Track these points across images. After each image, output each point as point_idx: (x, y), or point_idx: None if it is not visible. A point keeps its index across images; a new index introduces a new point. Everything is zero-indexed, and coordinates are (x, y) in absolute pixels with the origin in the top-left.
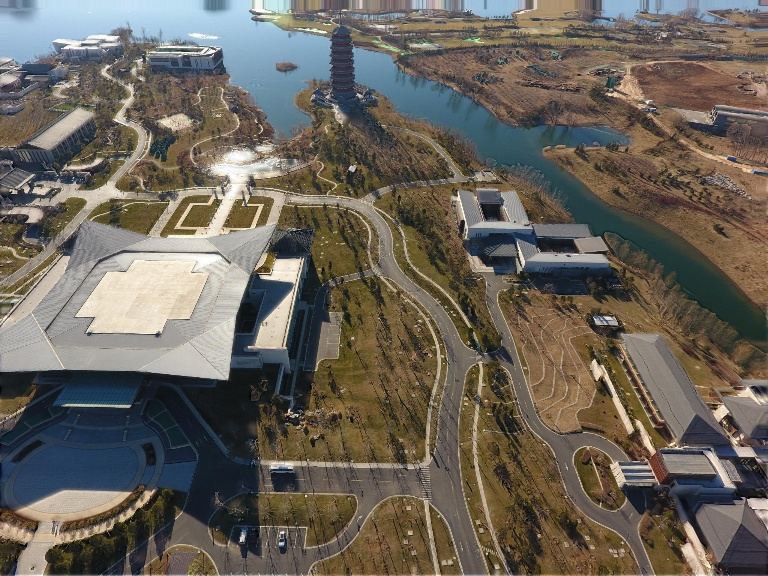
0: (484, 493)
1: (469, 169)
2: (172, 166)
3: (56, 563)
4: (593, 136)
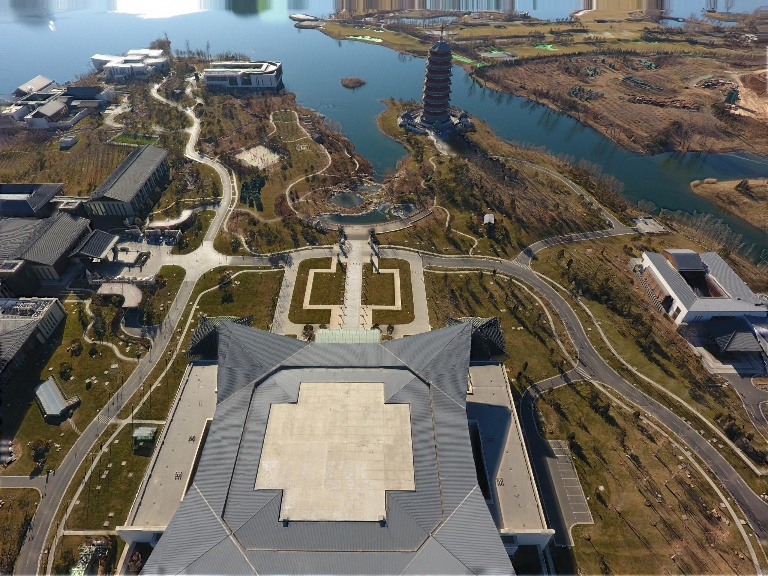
0: None
1: (628, 216)
2: (272, 217)
3: None
4: (739, 165)
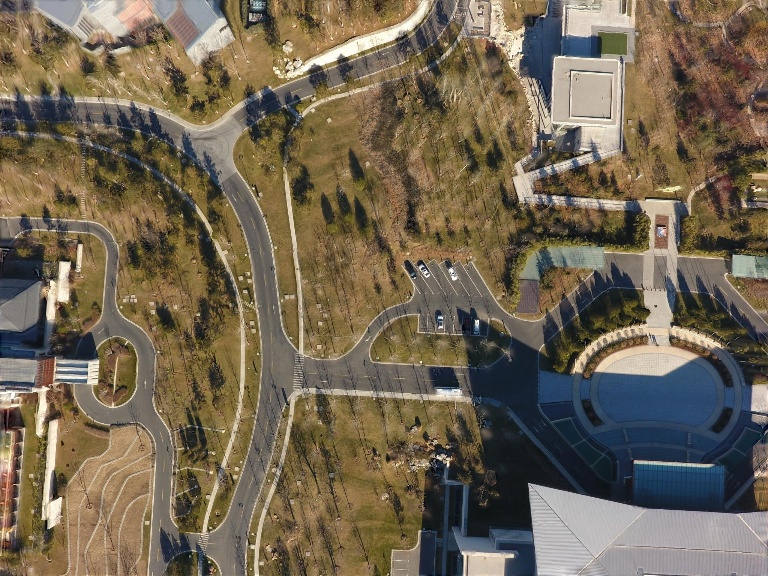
0: (241, 359)
1: None
2: None
3: (638, 308)
4: None
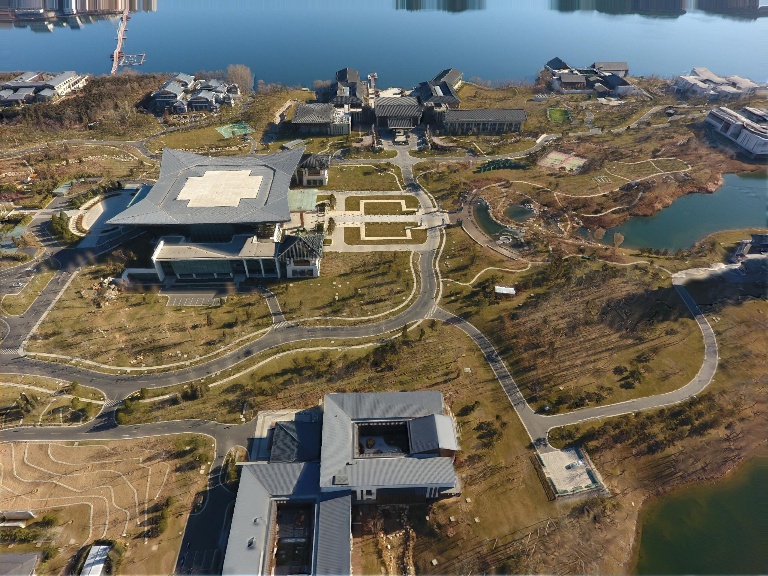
0: None
1: None
2: (467, 178)
3: None
4: None
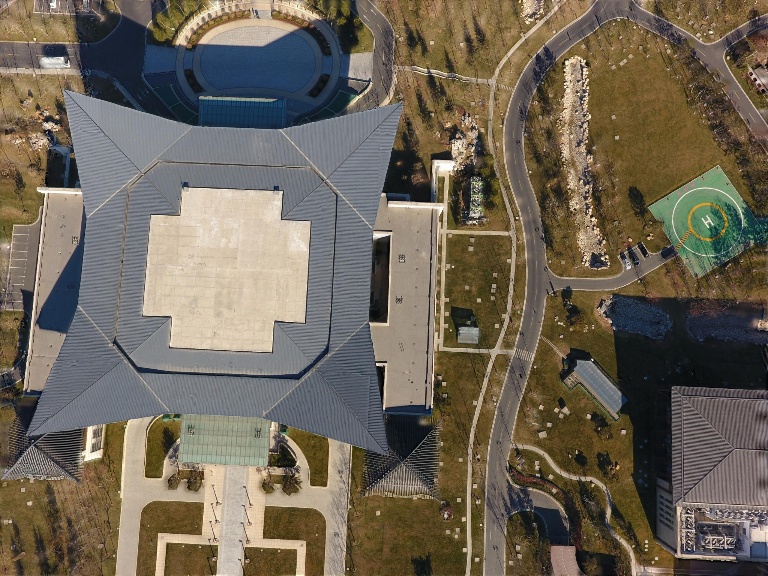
0: None
1: None
2: None
3: None
4: None
